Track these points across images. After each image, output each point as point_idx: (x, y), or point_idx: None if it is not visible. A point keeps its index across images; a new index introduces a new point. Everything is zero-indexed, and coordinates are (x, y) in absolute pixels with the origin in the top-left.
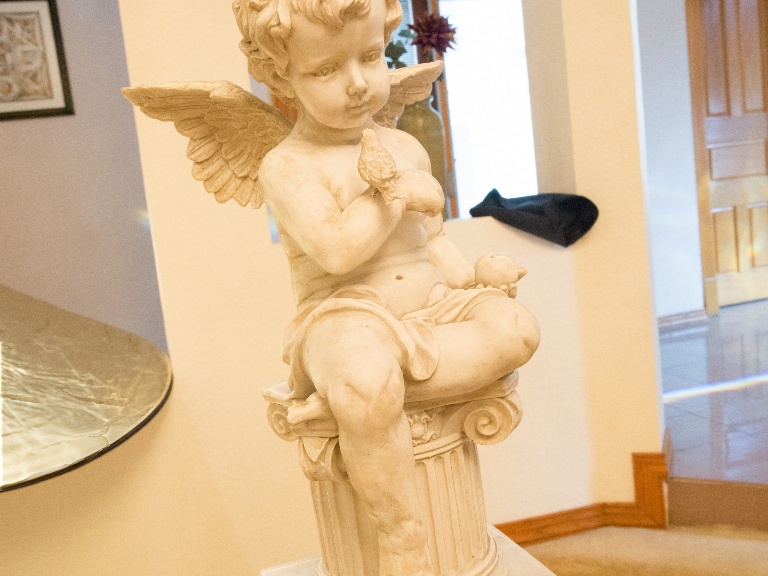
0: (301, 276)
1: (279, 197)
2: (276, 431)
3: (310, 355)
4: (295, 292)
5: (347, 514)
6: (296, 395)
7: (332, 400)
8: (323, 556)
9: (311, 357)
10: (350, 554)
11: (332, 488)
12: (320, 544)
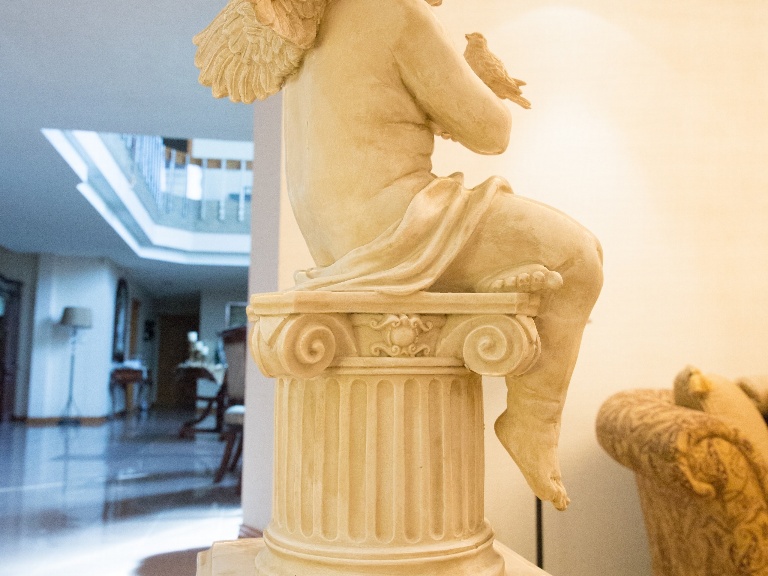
0: (408, 145)
1: (451, 46)
2: (291, 363)
3: (534, 221)
4: (394, 162)
5: (463, 436)
6: (431, 284)
7: (593, 262)
8: (405, 520)
9: (538, 223)
10: (456, 492)
11: (450, 406)
12: (403, 502)
